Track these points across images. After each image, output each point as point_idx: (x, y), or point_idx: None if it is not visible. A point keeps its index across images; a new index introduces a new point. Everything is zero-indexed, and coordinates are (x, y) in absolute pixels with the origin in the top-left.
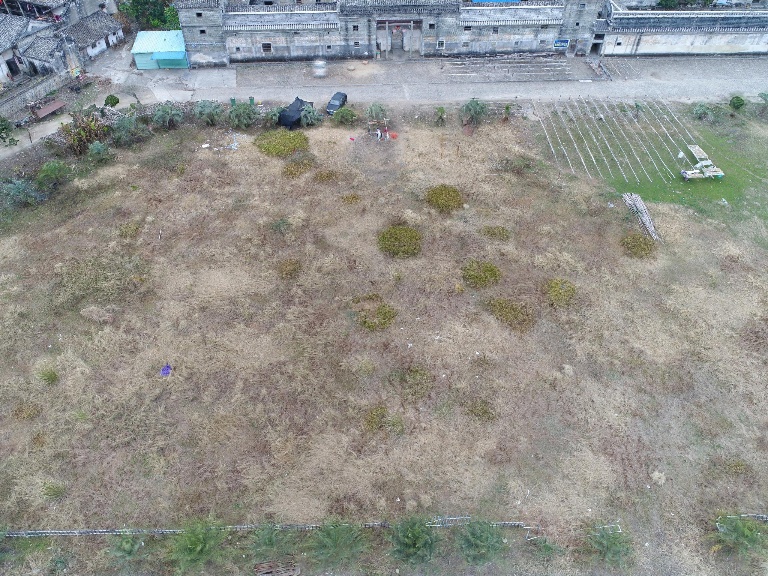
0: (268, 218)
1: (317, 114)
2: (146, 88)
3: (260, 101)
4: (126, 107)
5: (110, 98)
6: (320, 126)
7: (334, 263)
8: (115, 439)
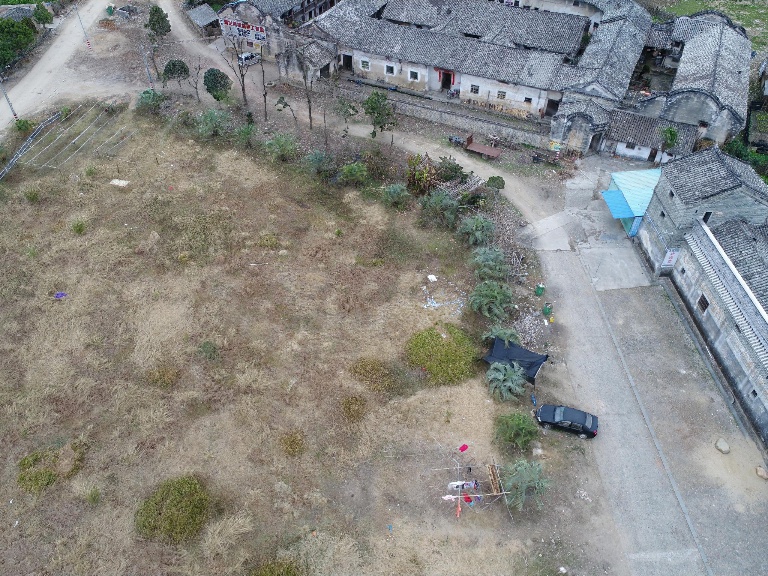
0: (264, 350)
1: (515, 389)
2: (562, 208)
3: (560, 321)
4: (511, 200)
5: (494, 178)
6: (497, 400)
7: (154, 422)
8: (3, 276)
